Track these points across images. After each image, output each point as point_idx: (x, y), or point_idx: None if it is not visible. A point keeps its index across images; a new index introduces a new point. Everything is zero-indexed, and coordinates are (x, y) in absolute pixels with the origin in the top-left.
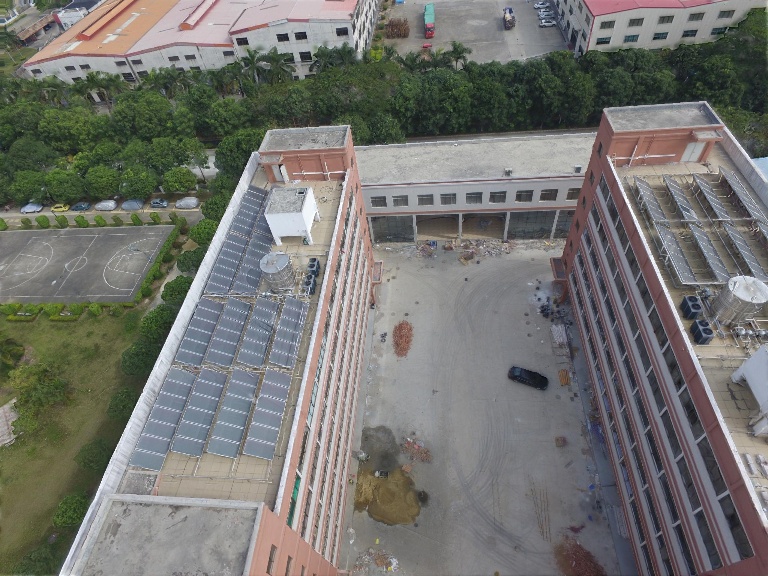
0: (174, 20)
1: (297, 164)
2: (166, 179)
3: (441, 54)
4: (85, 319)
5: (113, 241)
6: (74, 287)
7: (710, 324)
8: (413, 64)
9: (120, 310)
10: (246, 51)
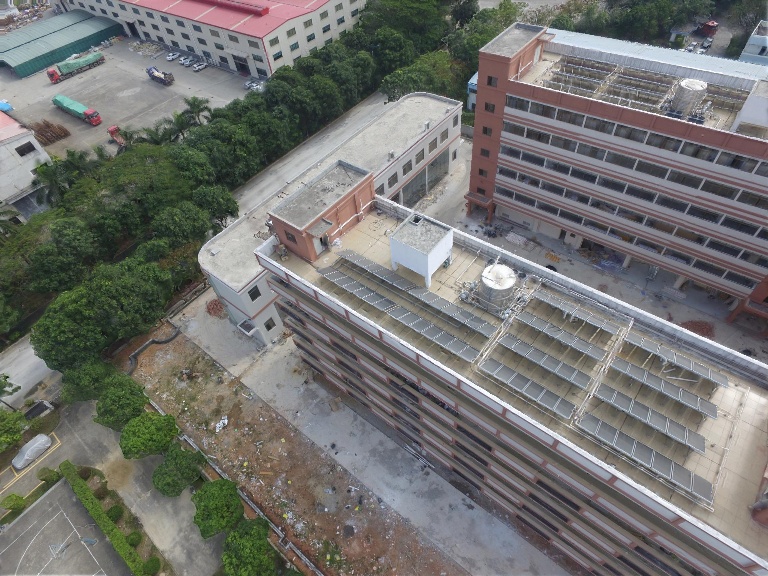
0: None
1: (334, 220)
2: None
3: (180, 115)
4: None
5: None
6: None
7: None
8: (158, 138)
9: None
10: None
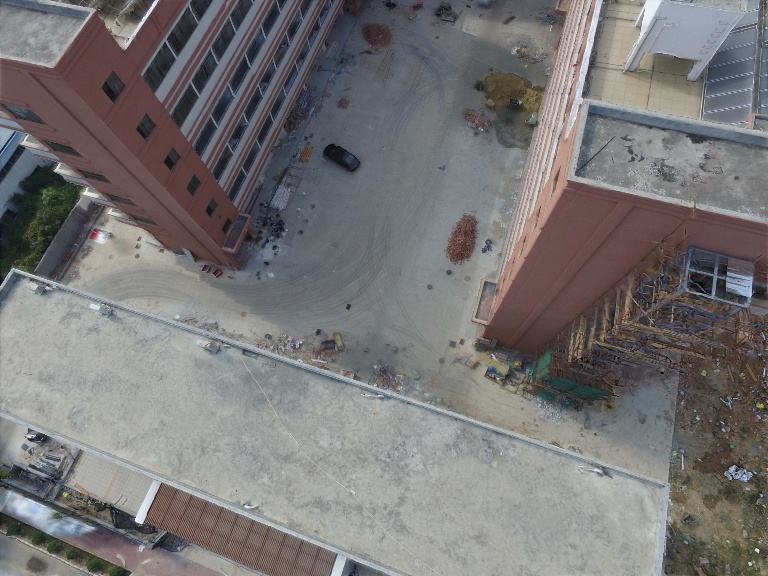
0: None
1: None
2: None
3: None
4: None
5: None
6: None
7: None
8: None
9: None
10: None
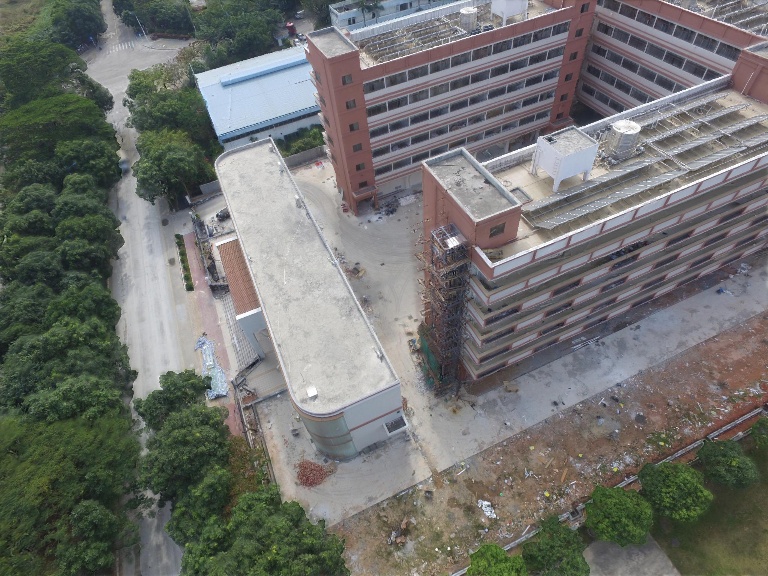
0: None
1: None
2: None
3: None
4: None
5: None
6: None
7: None
8: None
9: None
10: None
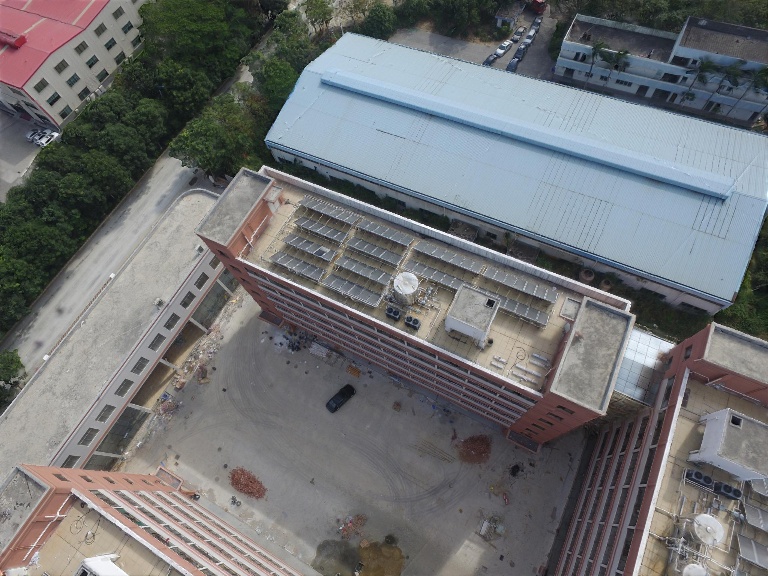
0: None
1: (18, 553)
2: None
3: None
4: None
5: None
6: None
7: (410, 314)
8: None
9: None
10: None
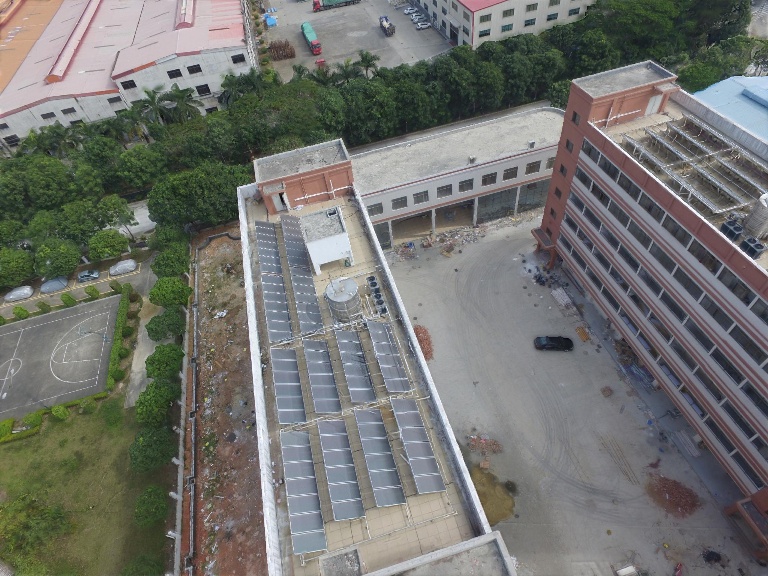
0: (32, 74)
1: (299, 188)
2: (93, 246)
3: (351, 65)
4: (49, 428)
5: (47, 331)
6: (17, 396)
7: None
8: (325, 79)
9: (93, 404)
10: (134, 94)
